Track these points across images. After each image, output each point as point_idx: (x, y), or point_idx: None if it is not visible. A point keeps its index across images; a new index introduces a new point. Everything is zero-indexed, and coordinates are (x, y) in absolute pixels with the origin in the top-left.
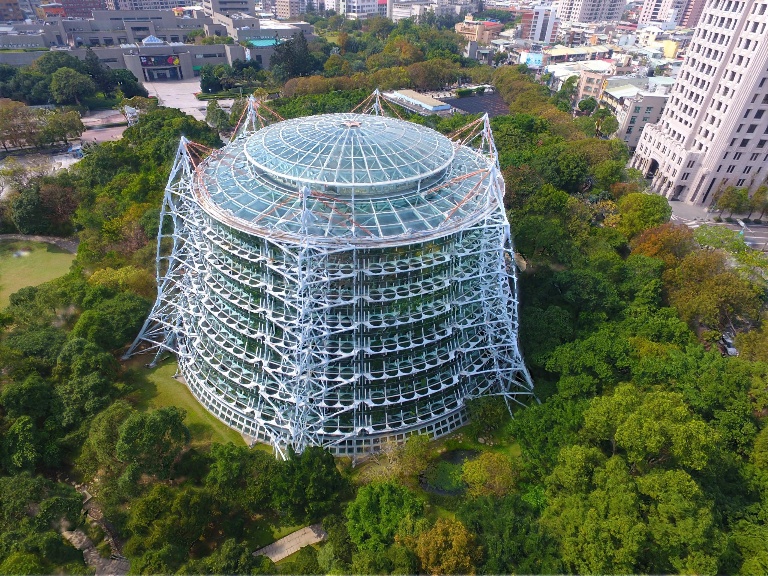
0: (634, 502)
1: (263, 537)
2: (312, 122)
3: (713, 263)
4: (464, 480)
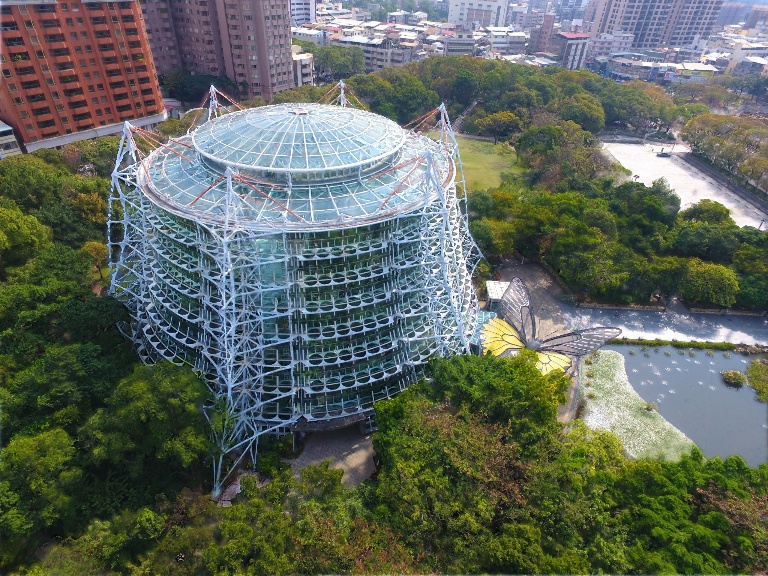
0: None
1: None
2: (334, 108)
3: None
4: None
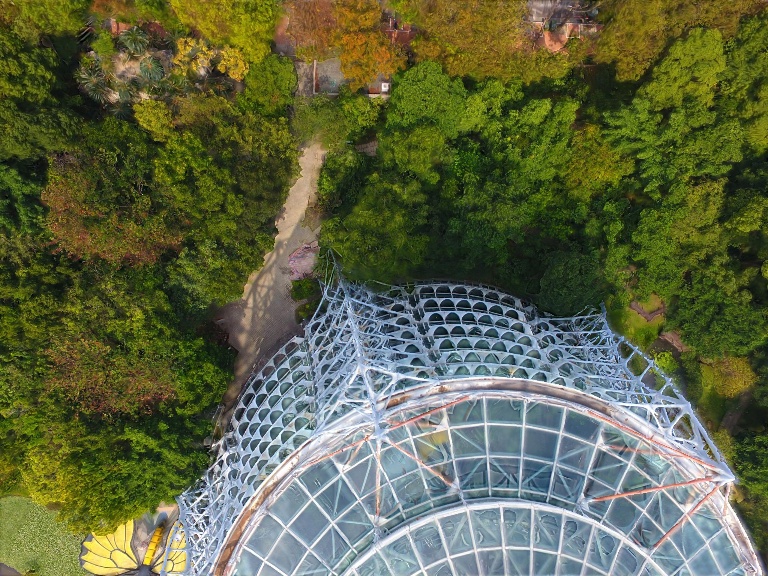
0: None
1: None
2: None
3: (472, 0)
4: (733, 396)
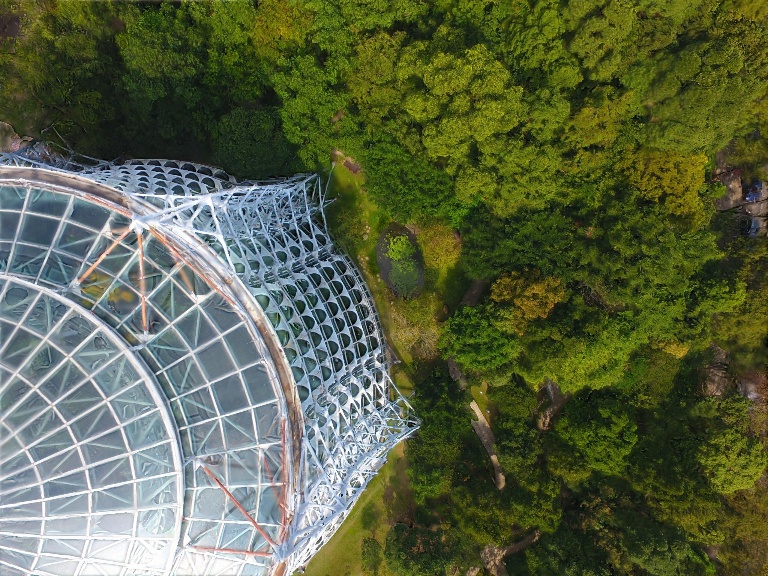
0: (524, 144)
1: None
2: None
3: None
4: (442, 268)
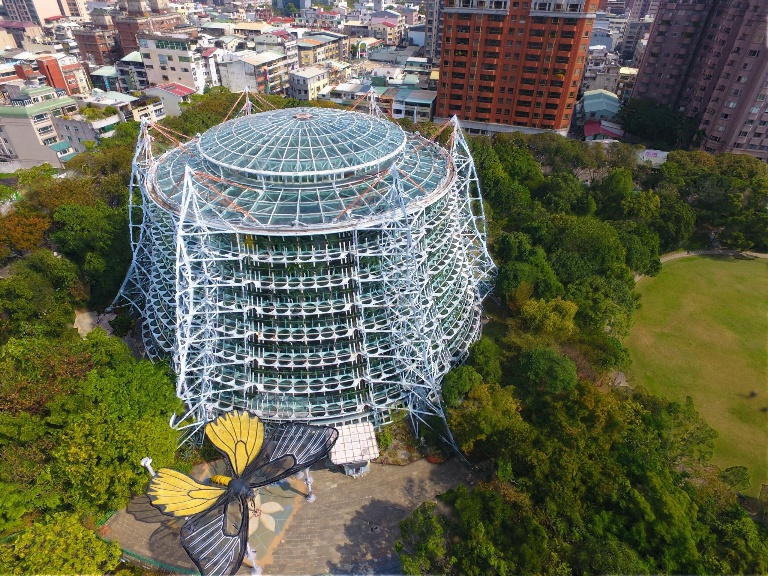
0: None
1: None
2: None
3: (53, 183)
4: None
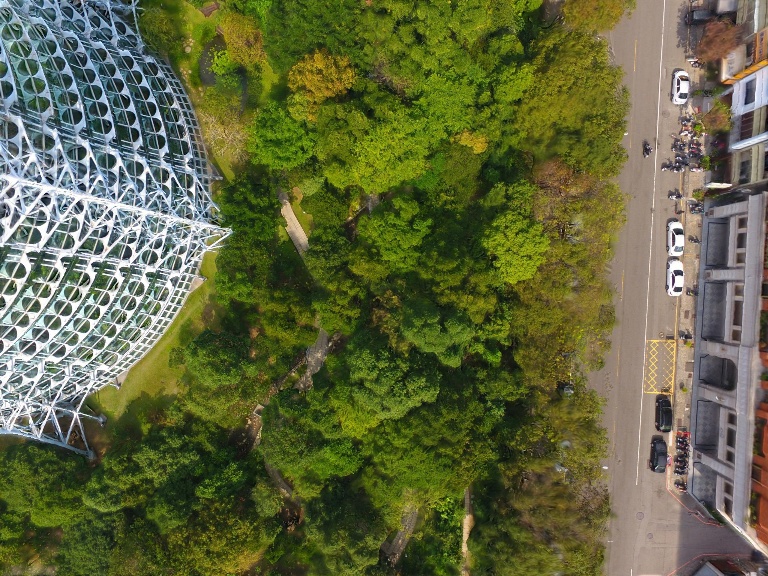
0: None
1: (288, 249)
2: None
3: None
4: (247, 64)
